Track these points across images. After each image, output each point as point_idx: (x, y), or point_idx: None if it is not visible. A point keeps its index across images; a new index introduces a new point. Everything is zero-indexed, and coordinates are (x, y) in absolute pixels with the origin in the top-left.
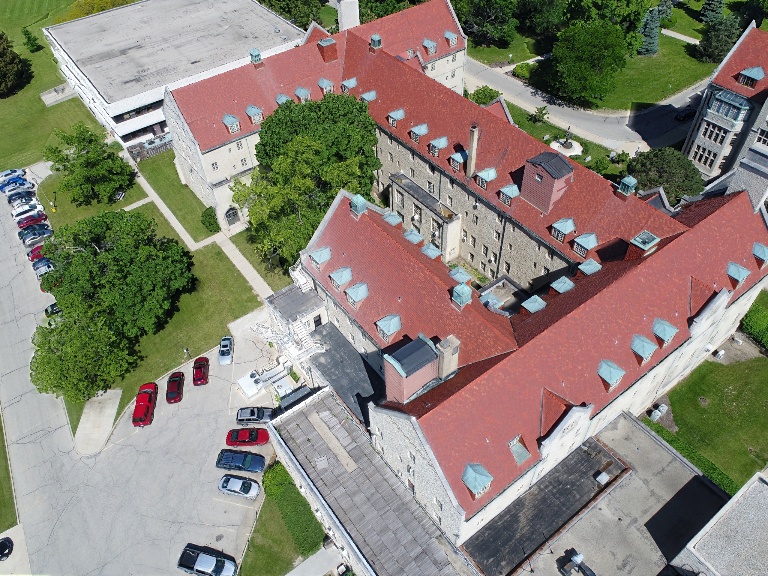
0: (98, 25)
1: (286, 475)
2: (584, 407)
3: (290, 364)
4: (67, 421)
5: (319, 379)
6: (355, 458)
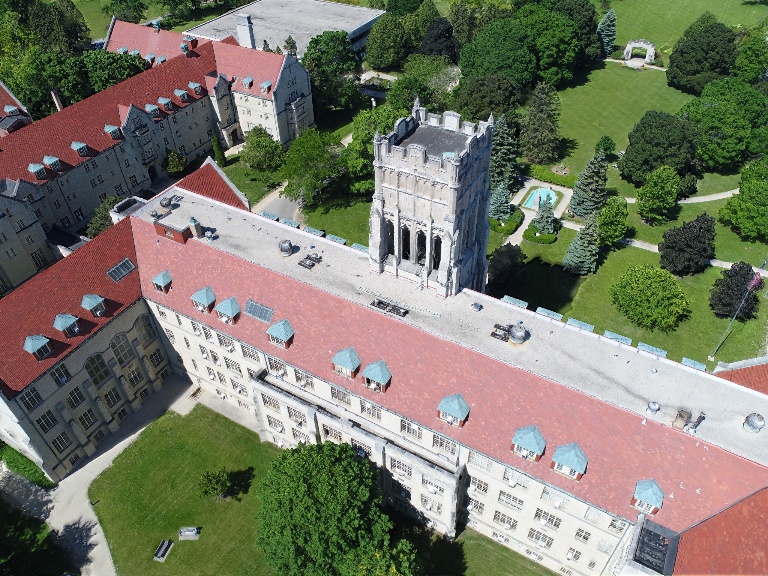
0: (289, 3)
1: None
2: None
3: None
4: None
5: None
6: None
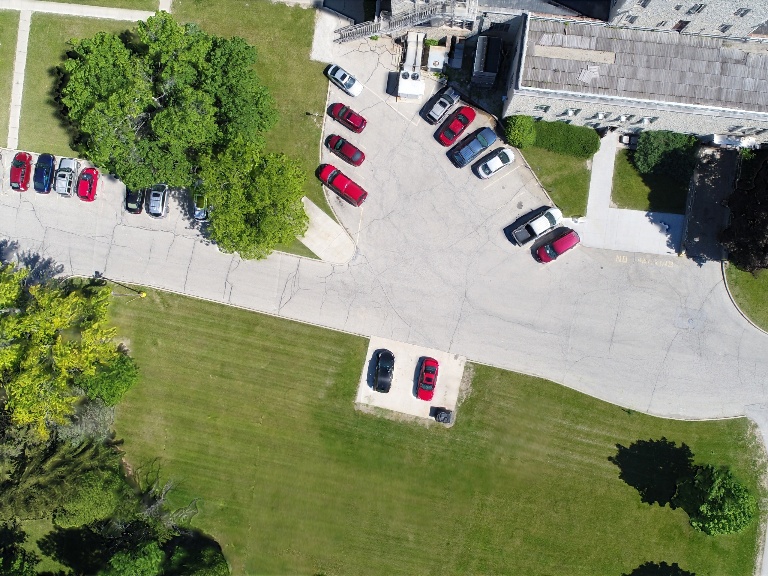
0: None
1: (529, 120)
2: None
3: (423, 36)
4: (297, 257)
5: (505, 16)
6: (606, 49)
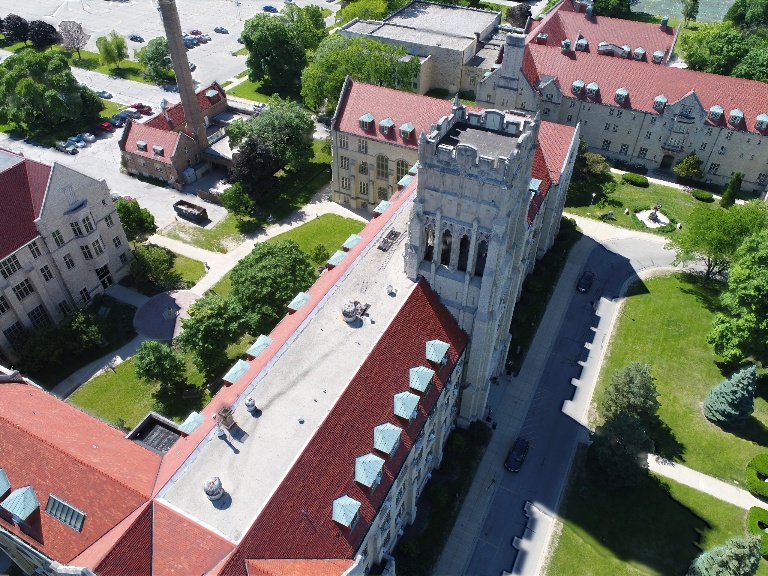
0: None
1: None
2: (526, 26)
3: None
4: None
5: None
6: None
